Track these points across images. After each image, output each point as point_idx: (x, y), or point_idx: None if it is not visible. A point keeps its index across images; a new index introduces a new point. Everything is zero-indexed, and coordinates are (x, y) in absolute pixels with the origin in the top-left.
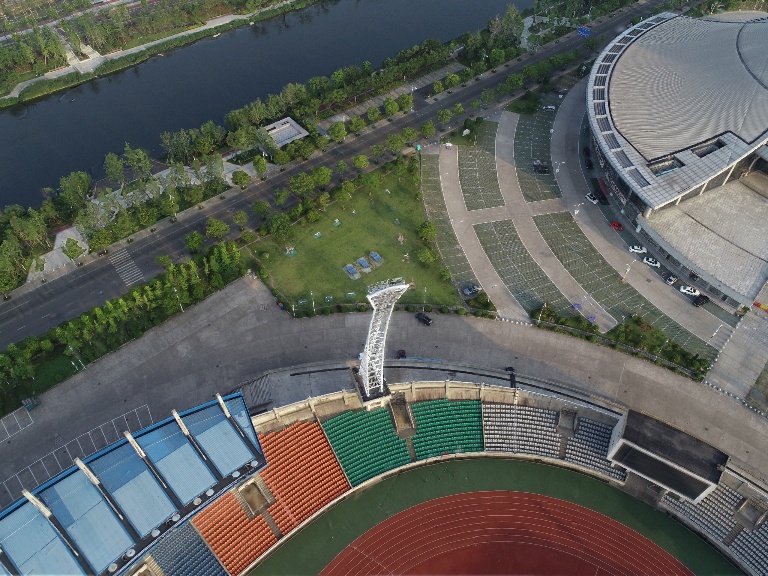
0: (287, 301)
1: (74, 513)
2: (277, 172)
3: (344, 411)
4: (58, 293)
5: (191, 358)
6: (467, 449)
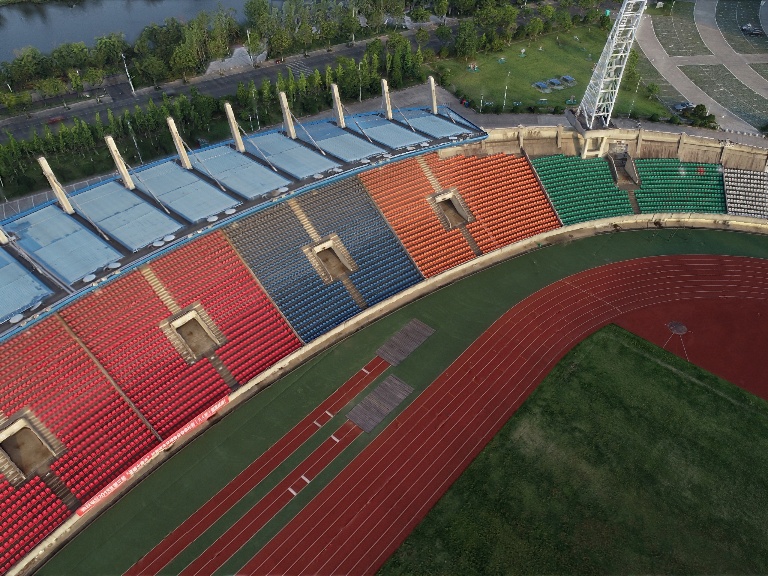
0: None
1: (270, 151)
2: (455, 23)
3: (555, 154)
4: (235, 83)
5: None
6: (704, 211)
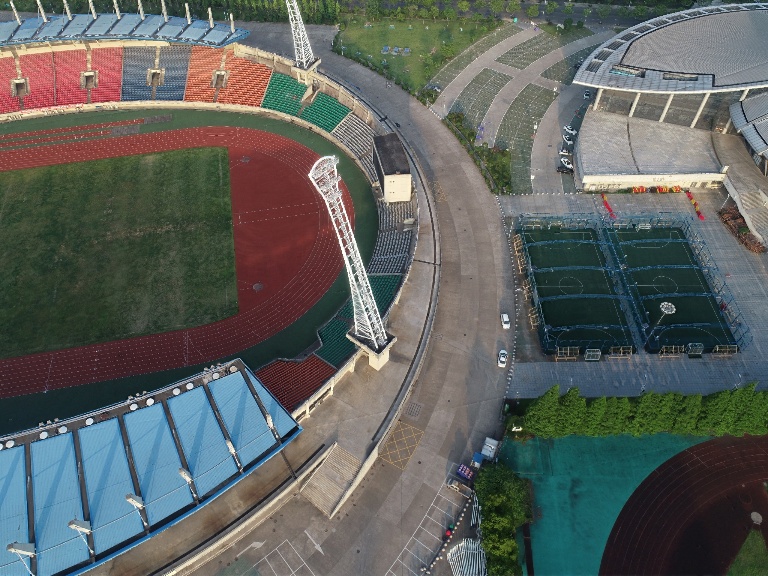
0: (338, 43)
1: None
2: None
3: (288, 75)
4: None
5: (270, 40)
6: (324, 128)
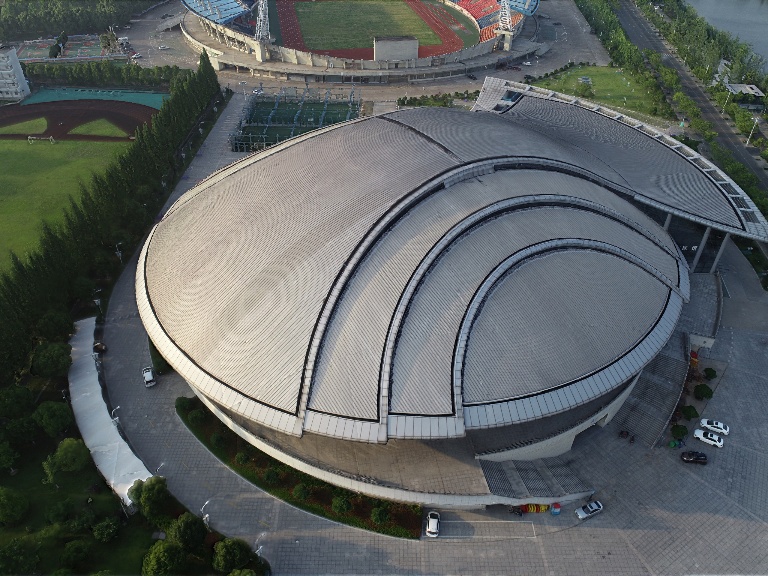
0: None
1: None
2: None
3: None
4: None
5: None
6: None
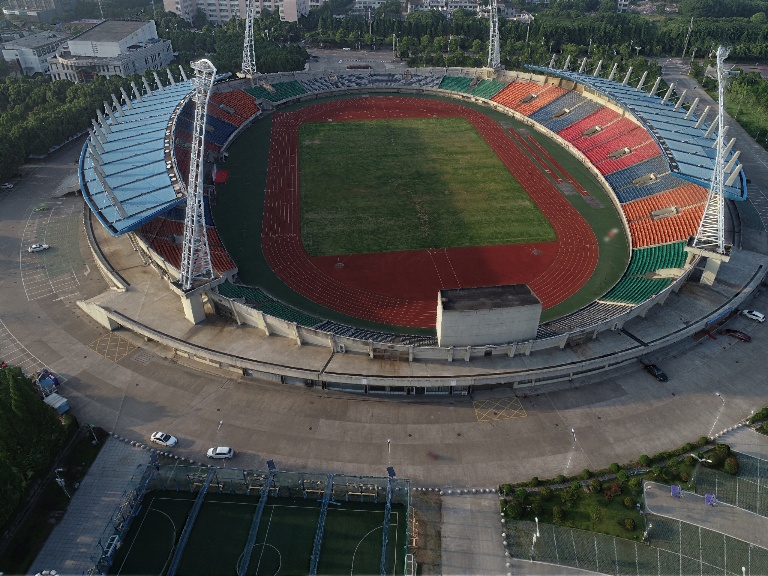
0: None
1: None
2: None
3: None
4: None
5: None
6: (608, 296)
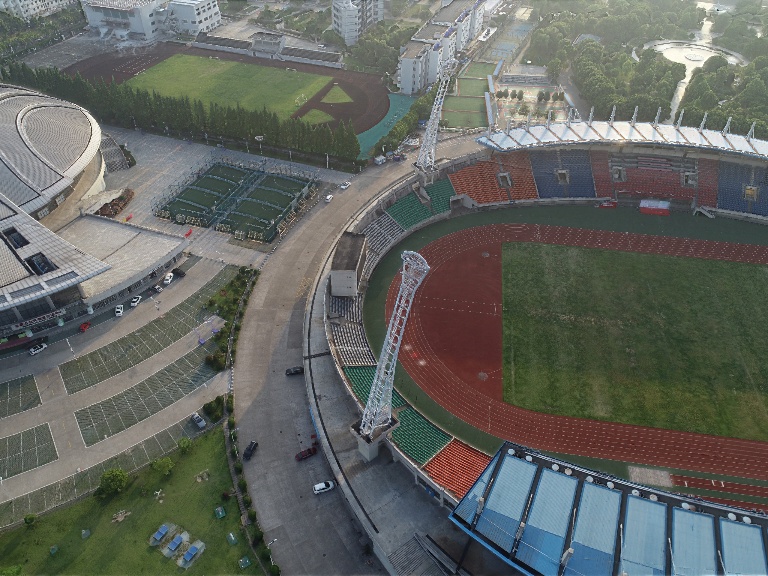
0: None
1: None
2: None
3: None
4: None
5: None
6: None
